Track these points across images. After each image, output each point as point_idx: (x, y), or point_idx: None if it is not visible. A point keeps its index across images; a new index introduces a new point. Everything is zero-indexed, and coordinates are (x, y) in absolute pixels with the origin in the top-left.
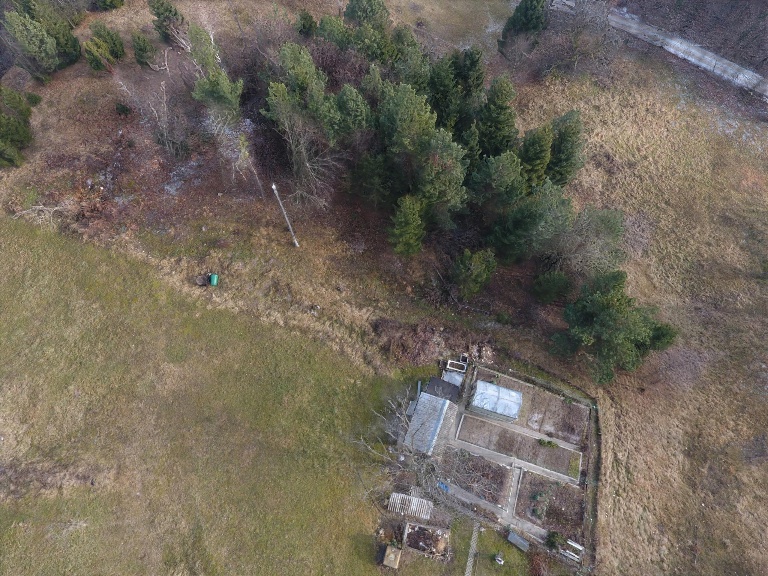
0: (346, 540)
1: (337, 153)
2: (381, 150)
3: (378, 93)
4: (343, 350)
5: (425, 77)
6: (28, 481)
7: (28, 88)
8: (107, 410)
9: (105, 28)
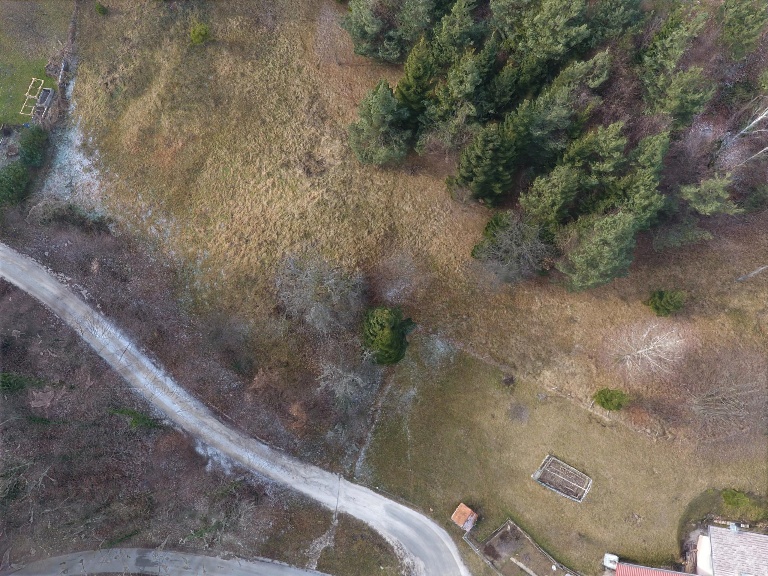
0: None
1: None
2: None
3: None
4: None
5: None
6: None
7: None
8: None
9: None
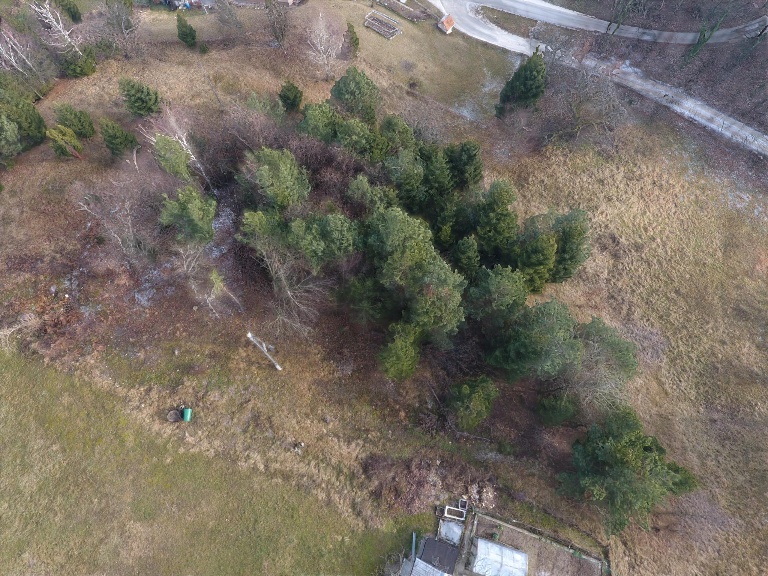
0: None
1: (321, 279)
2: (370, 270)
3: (367, 201)
4: (330, 498)
5: (418, 177)
6: None
7: None
8: None
9: (72, 110)
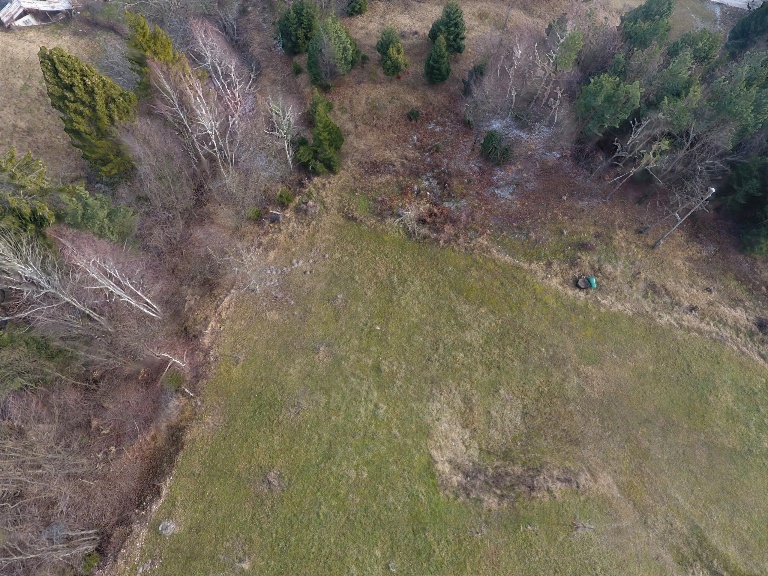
0: None
1: (727, 156)
2: None
3: None
4: (741, 350)
5: (759, 79)
6: (509, 485)
7: (308, 95)
8: (545, 413)
9: None
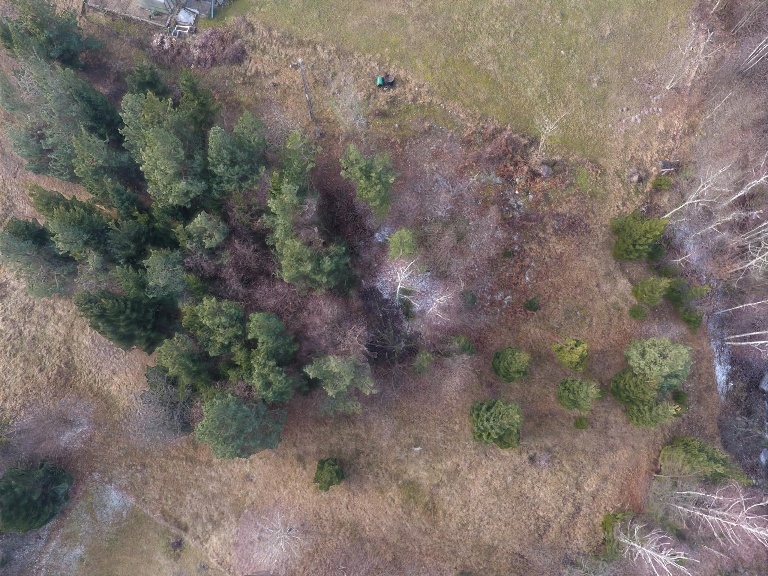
0: None
1: None
2: None
3: None
4: (269, 32)
5: None
6: None
7: None
8: None
9: (579, 398)
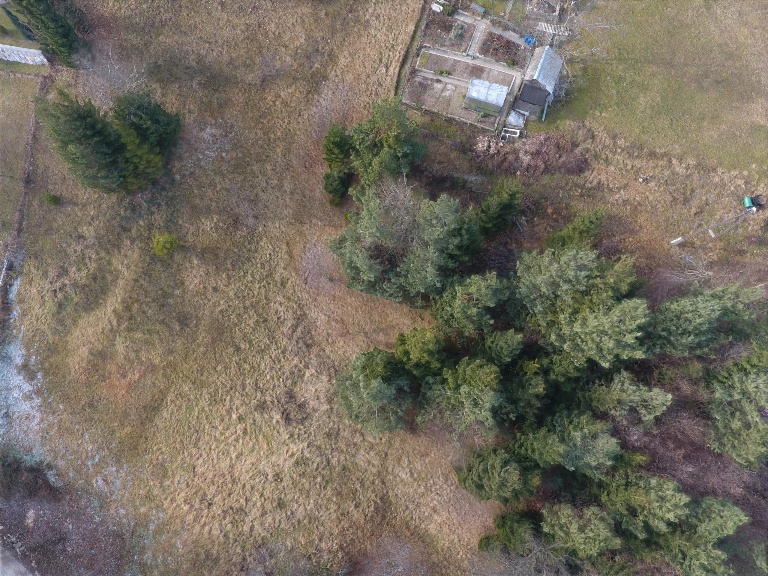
0: (600, 6)
1: None
2: None
3: None
4: (614, 140)
5: None
6: None
7: None
8: None
9: None
